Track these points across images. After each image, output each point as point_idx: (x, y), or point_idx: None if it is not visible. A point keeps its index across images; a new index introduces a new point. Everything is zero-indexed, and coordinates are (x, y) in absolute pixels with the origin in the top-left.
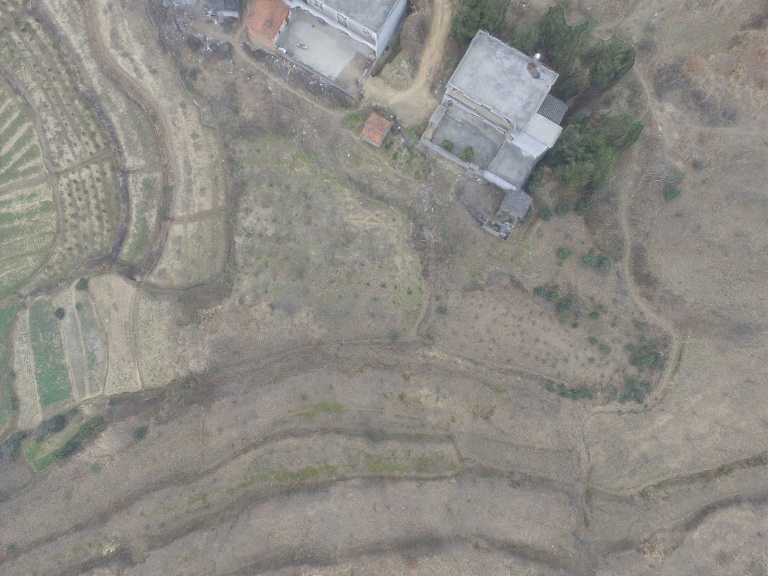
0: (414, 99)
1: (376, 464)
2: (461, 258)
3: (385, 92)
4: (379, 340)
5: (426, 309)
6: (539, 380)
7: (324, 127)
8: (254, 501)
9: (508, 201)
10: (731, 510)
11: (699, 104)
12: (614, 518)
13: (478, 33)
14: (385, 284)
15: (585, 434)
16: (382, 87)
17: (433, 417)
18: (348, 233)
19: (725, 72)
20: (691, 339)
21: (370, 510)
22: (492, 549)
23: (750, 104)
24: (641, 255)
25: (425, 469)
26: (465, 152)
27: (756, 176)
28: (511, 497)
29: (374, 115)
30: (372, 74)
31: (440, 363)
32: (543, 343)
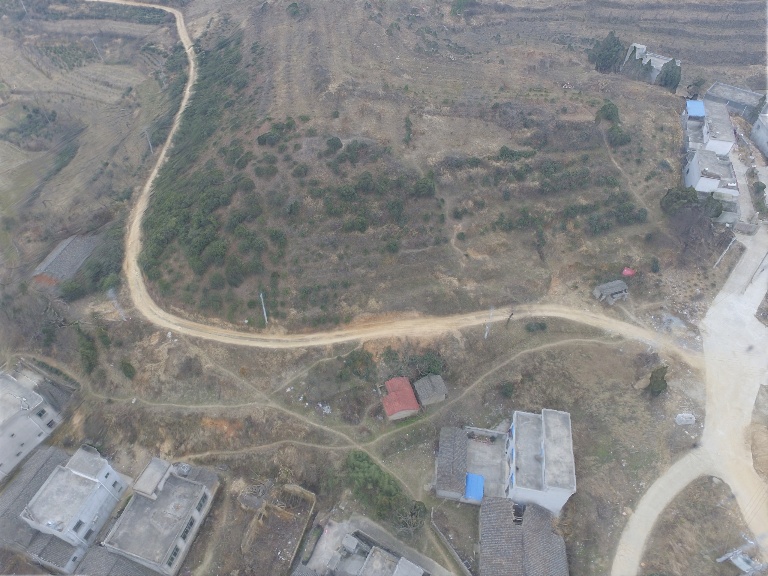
0: None
1: None
2: None
3: None
4: None
5: None
6: None
7: None
8: (720, 23)
9: None
10: (538, 8)
11: None
12: None
13: None
14: None
15: None
16: None
17: None
18: None
19: None
20: None
21: None
22: (626, 5)
23: None
24: None
25: None
26: None
27: None
28: None
29: (700, 93)
30: None
31: None
32: None
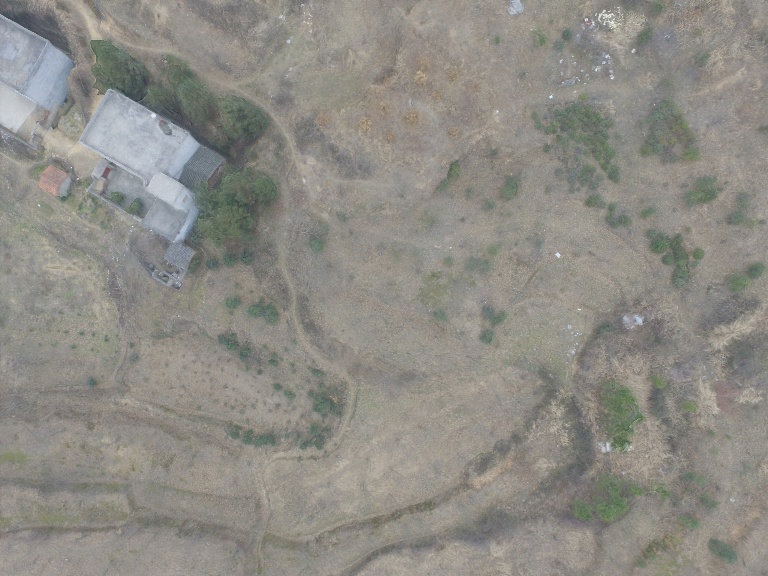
0: (90, 151)
1: (48, 515)
2: (141, 307)
3: (64, 144)
4: (79, 387)
5: (124, 356)
6: (225, 426)
7: (14, 178)
8: None
9: (169, 253)
10: (390, 557)
11: (335, 157)
12: (284, 565)
13: (107, 92)
14: (84, 332)
15: (265, 481)
16: (61, 139)
17: (112, 466)
18: (47, 281)
19: (356, 126)
20: (365, 385)
21: (30, 563)
22: None
23: (380, 157)
24: (303, 304)
25: (95, 519)
26: (131, 204)
27: (402, 226)
28: (176, 547)
29: (50, 167)
30: (53, 126)
31: (131, 411)
32: (232, 389)
